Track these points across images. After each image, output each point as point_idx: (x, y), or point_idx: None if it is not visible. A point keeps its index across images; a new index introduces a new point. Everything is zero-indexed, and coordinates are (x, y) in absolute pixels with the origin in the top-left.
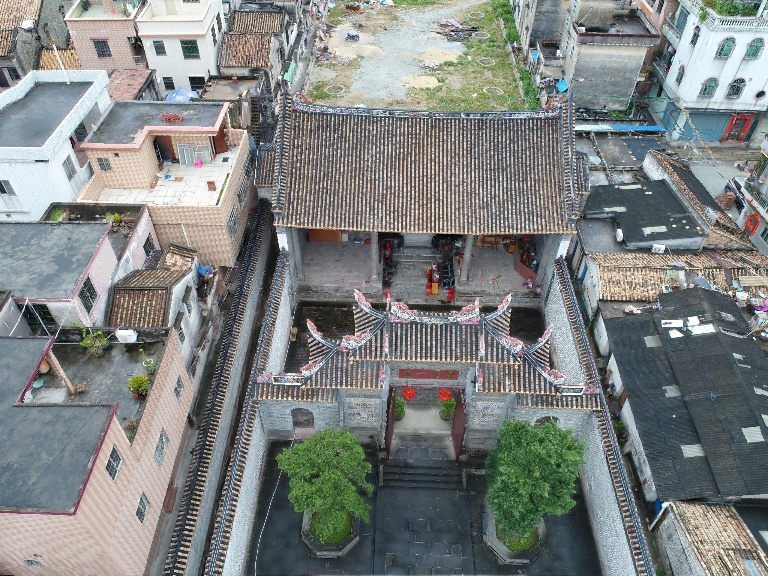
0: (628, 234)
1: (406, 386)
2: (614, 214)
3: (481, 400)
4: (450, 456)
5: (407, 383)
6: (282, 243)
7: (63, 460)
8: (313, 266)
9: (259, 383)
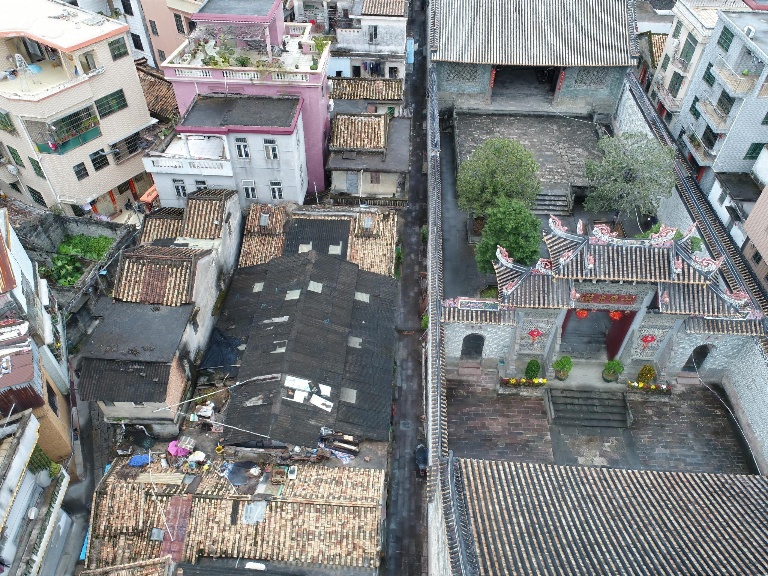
0: None
1: None
2: None
3: None
4: None
5: None
6: None
7: None
8: None
9: None
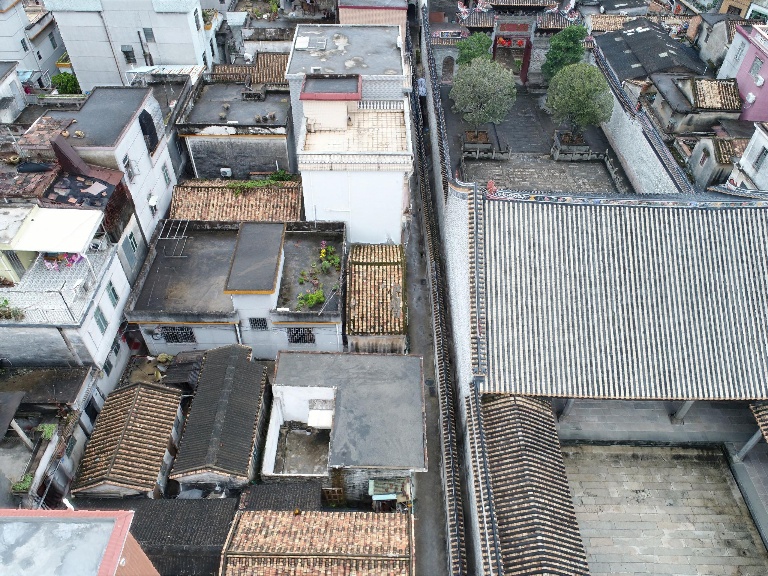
0: (607, 8)
1: (503, 36)
2: (599, 2)
3: (537, 47)
4: (520, 84)
5: (504, 34)
6: (424, 1)
7: (395, 0)
8: (431, 30)
9: (433, 37)
